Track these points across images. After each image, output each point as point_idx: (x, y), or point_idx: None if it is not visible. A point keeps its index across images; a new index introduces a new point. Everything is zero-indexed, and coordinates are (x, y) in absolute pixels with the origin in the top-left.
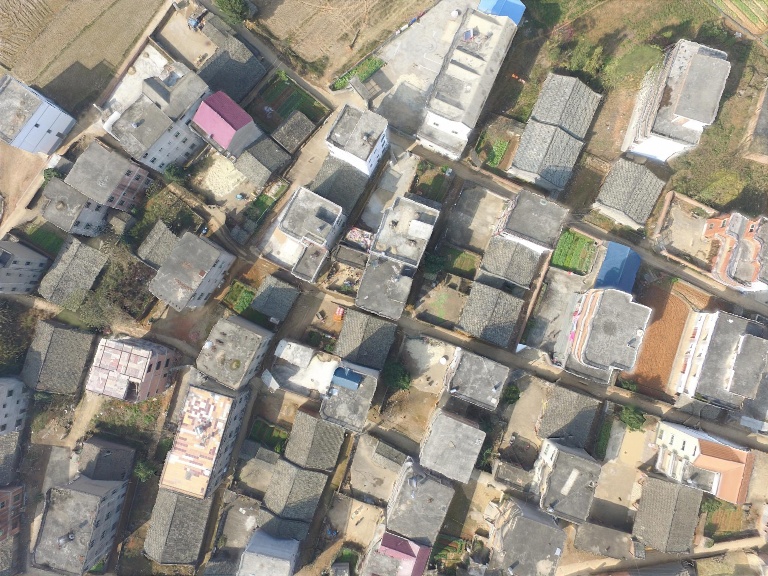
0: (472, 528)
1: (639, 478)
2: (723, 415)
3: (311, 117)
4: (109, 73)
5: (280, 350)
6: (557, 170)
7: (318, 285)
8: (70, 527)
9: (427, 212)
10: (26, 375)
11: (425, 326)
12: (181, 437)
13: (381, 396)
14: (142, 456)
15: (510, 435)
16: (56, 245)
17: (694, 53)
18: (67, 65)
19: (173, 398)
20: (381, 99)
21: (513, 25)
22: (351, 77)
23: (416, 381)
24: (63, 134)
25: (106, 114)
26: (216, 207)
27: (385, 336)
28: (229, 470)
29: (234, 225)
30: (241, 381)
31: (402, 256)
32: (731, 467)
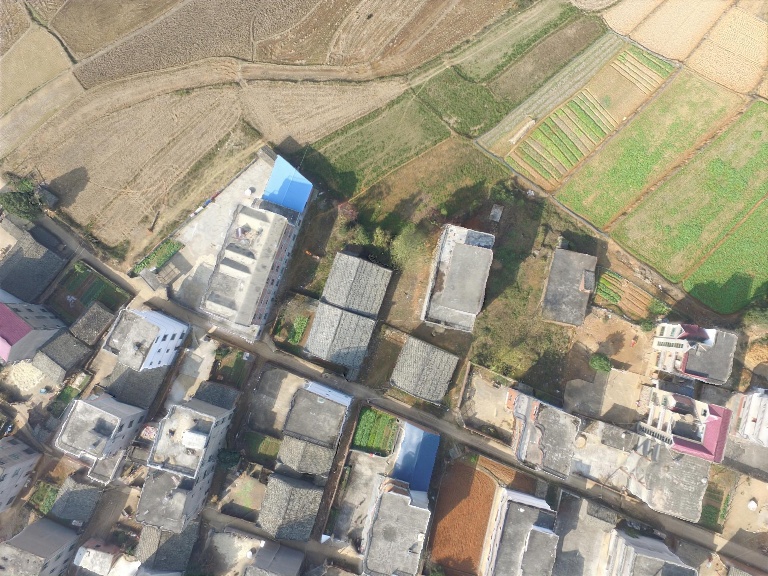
0: None
1: None
2: None
3: (112, 305)
4: None
5: (79, 558)
6: (349, 352)
7: (124, 479)
8: None
9: (204, 418)
10: None
11: (232, 517)
12: None
13: None
14: None
15: None
16: None
17: (463, 236)
18: None
19: None
20: (181, 282)
21: (283, 219)
22: (150, 261)
23: None
24: None
25: None
26: None
27: (186, 535)
28: None
29: (39, 420)
30: None
31: (181, 466)
32: None
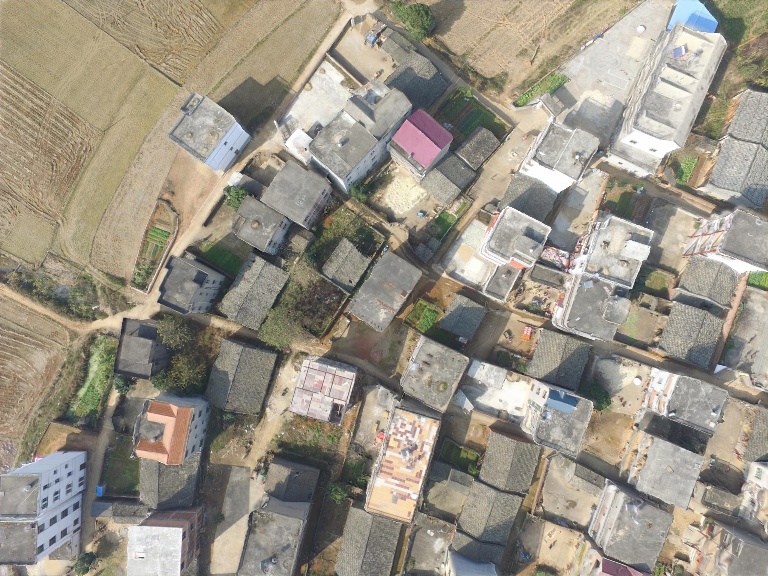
0: (670, 552)
1: None
2: None
3: None
4: (282, 89)
5: (473, 370)
6: (757, 188)
7: (504, 304)
8: (272, 551)
9: (639, 232)
10: (211, 395)
11: (616, 346)
12: (387, 460)
13: None
14: (326, 477)
15: (709, 457)
16: (232, 263)
17: None
18: (240, 81)
19: (357, 418)
20: (564, 115)
21: (723, 42)
22: (533, 93)
23: None
24: (239, 151)
25: (282, 130)
26: (396, 225)
27: (580, 356)
28: None
29: (415, 243)
30: (448, 403)
31: (614, 277)
32: None
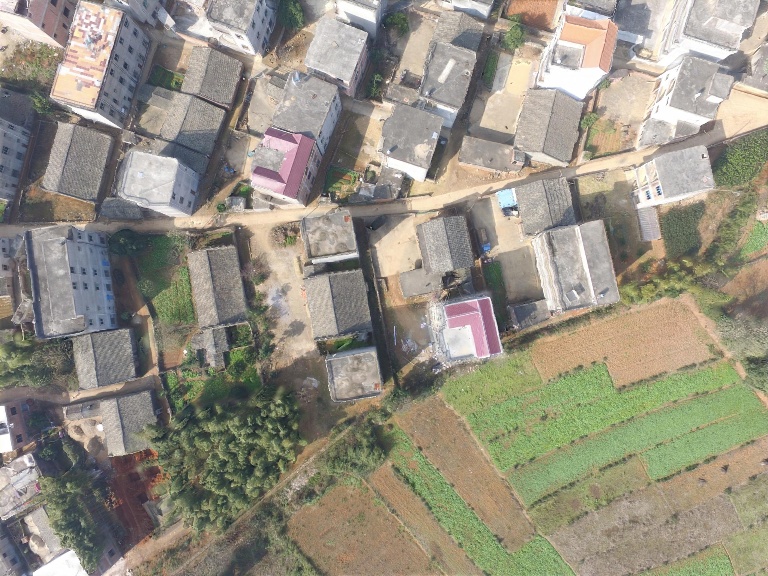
0: (365, 161)
1: None
2: None
3: None
4: None
5: None
6: None
7: None
8: None
9: None
10: None
11: None
12: (72, 50)
13: (277, 39)
14: None
15: (401, 71)
16: None
17: None
18: None
19: None
20: None
21: None
22: None
23: (312, 26)
24: None
25: None
26: None
27: None
28: (129, 117)
29: None
30: None
31: None
32: (595, 36)
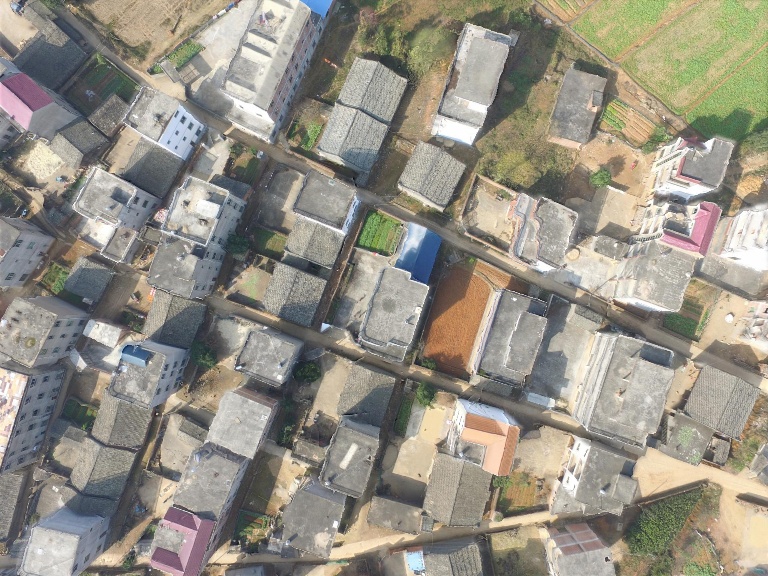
0: (277, 505)
1: (434, 454)
2: (519, 392)
3: (130, 101)
4: None
5: (88, 330)
6: (361, 152)
7: (134, 266)
8: None
9: (218, 192)
10: None
11: (236, 306)
12: None
13: (191, 375)
14: None
15: (314, 413)
16: None
17: (481, 37)
18: None
19: None
20: (199, 83)
21: (306, 9)
22: (170, 61)
23: (226, 360)
24: None
25: None
26: (37, 189)
27: (192, 316)
28: (43, 449)
29: None
30: (36, 359)
31: (194, 235)
32: (495, 440)
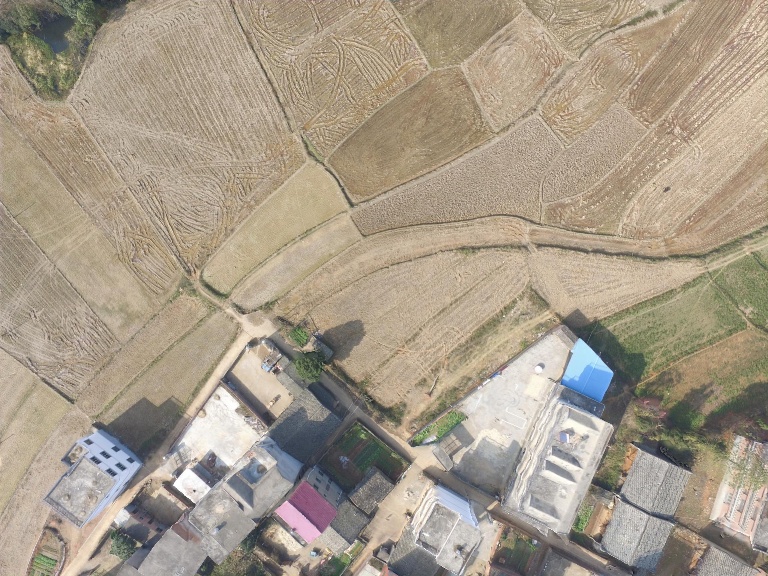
0: None
1: None
2: None
3: (389, 472)
4: (177, 411)
5: None
6: (648, 555)
7: None
8: None
9: None
10: None
11: None
12: None
13: None
14: None
15: None
16: None
17: None
18: (133, 401)
19: None
20: (461, 454)
21: (609, 427)
22: (430, 430)
23: None
24: (129, 479)
25: (174, 458)
26: None
27: None
28: None
29: None
30: None
31: None
32: None
